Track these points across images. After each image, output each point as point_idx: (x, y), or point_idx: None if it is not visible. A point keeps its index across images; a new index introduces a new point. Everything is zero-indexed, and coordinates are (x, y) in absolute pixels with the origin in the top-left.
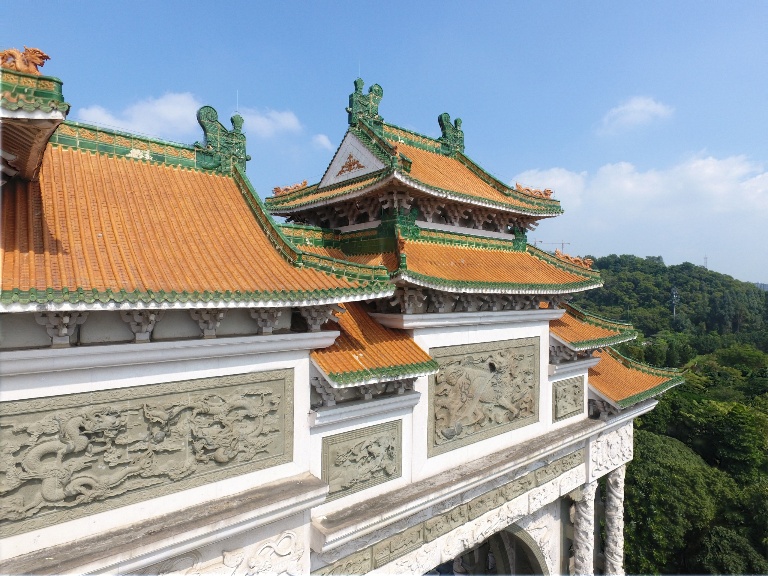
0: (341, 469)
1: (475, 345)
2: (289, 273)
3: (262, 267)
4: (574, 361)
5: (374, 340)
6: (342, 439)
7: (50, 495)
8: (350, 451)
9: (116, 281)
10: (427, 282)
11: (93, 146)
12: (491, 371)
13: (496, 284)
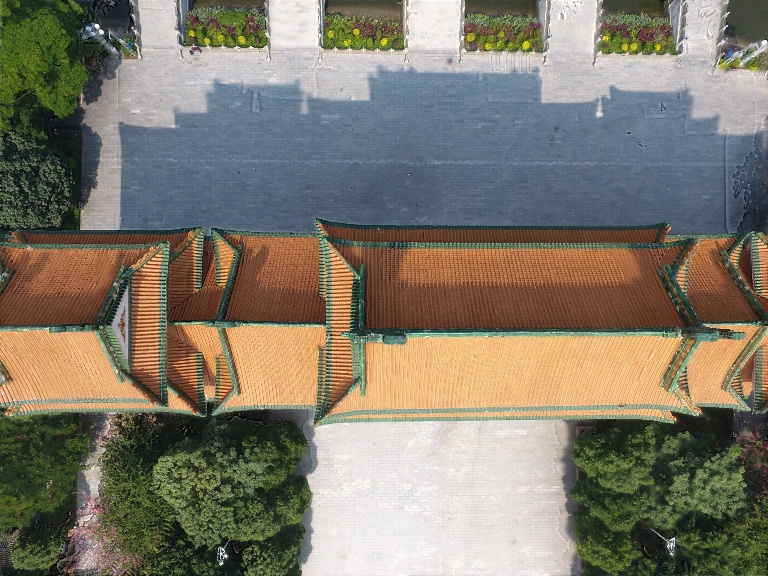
0: None
1: None
2: (715, 391)
3: None
4: None
5: None
6: None
7: None
8: None
9: None
10: None
11: None
12: None
13: None
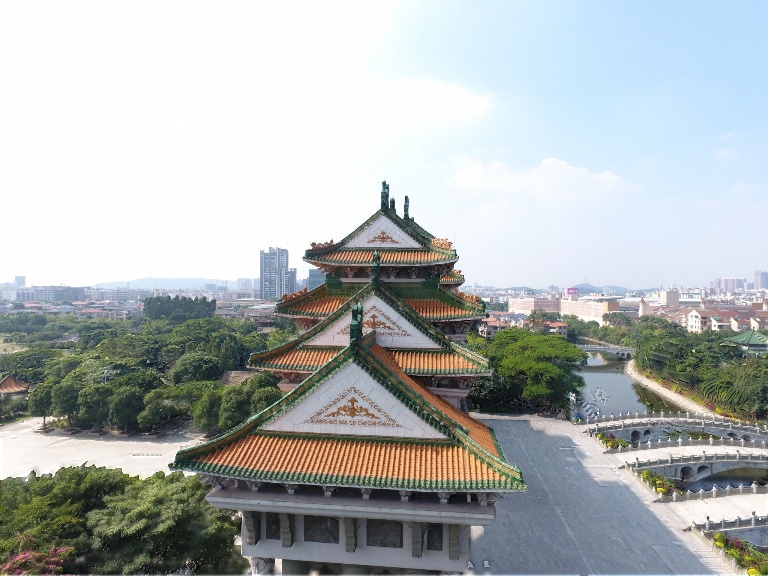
0: None
1: None
2: None
3: None
4: None
5: None
6: None
7: None
8: None
9: None
10: None
11: None
12: None
13: None
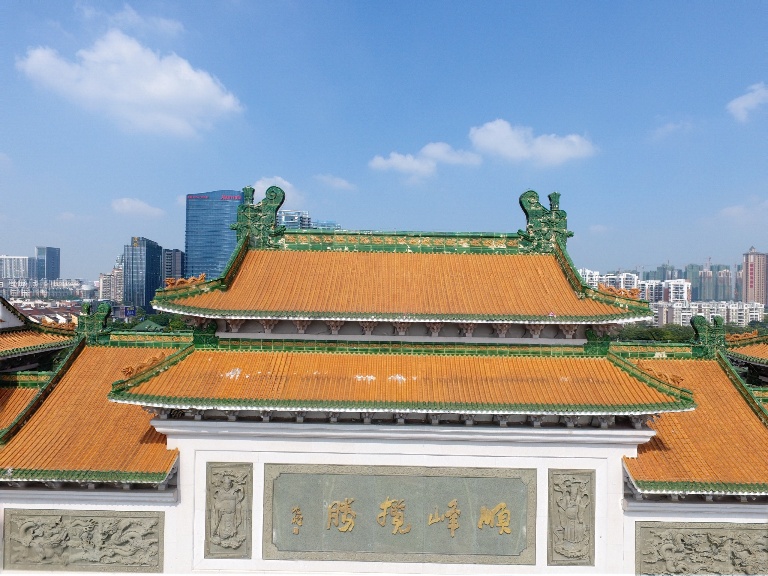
0: None
1: None
2: None
3: None
4: None
5: None
6: None
7: (670, 569)
8: None
9: (703, 474)
10: None
11: (637, 355)
12: None
13: None
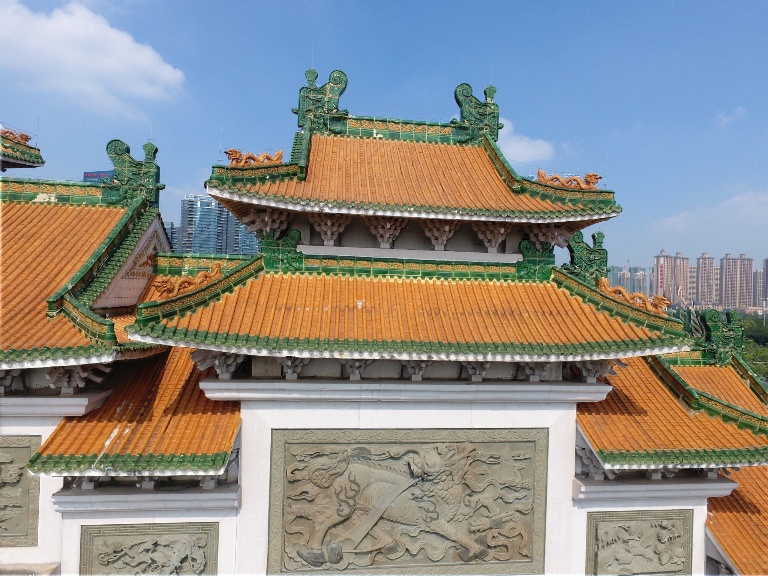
0: (111, 570)
1: (376, 431)
2: None
3: (8, 317)
4: (647, 481)
5: (179, 410)
6: (114, 532)
7: None
8: (122, 550)
9: None
10: (194, 342)
11: (5, 196)
12: (411, 475)
13: (372, 343)
